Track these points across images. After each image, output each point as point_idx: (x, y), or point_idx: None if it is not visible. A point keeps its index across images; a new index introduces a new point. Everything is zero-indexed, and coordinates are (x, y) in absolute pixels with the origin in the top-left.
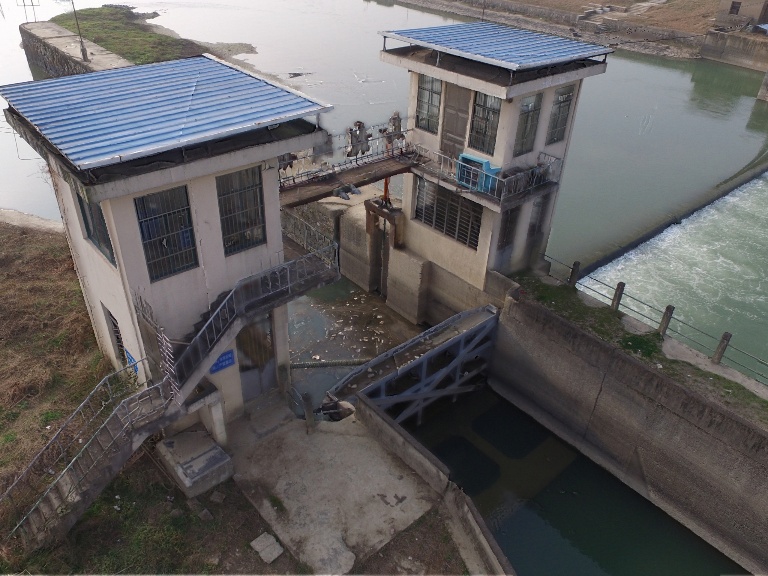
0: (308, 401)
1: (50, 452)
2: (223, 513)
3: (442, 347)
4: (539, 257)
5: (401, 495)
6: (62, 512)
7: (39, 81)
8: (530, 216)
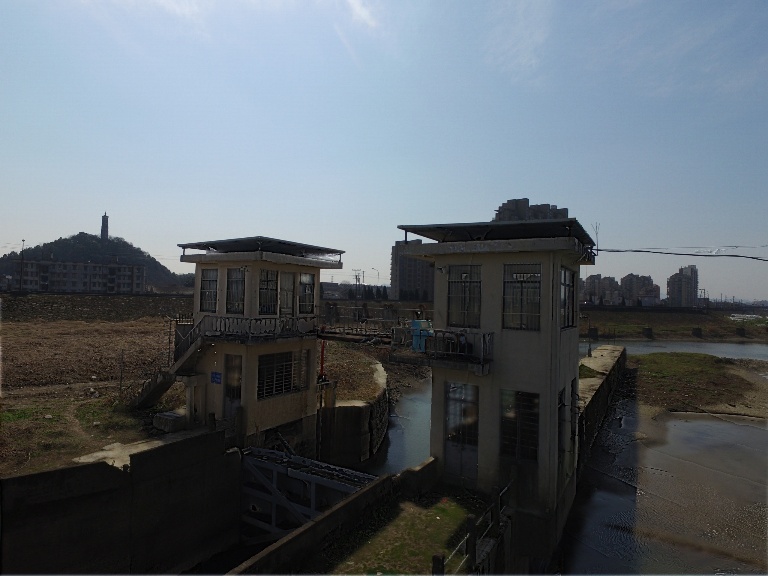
0: (210, 417)
1: None
2: (141, 433)
3: (332, 484)
4: (539, 503)
5: None
6: (136, 393)
7: None
8: (499, 419)
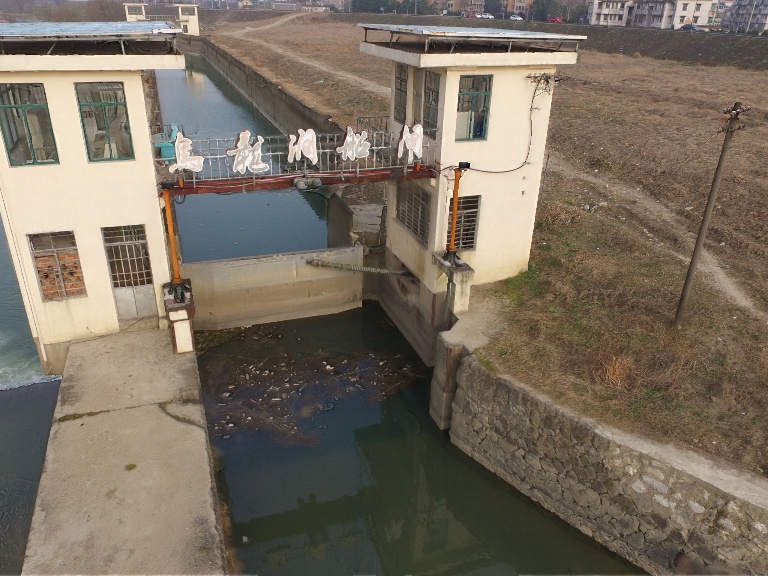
0: None
1: (536, 233)
2: None
3: None
4: None
5: (352, 209)
6: None
7: (560, 36)
8: None
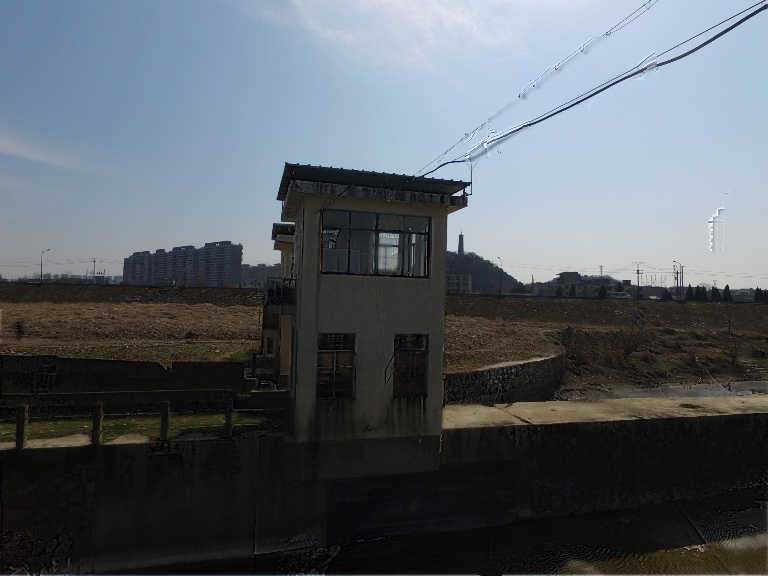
0: None
1: None
2: None
3: None
4: None
5: None
6: None
7: None
8: None
